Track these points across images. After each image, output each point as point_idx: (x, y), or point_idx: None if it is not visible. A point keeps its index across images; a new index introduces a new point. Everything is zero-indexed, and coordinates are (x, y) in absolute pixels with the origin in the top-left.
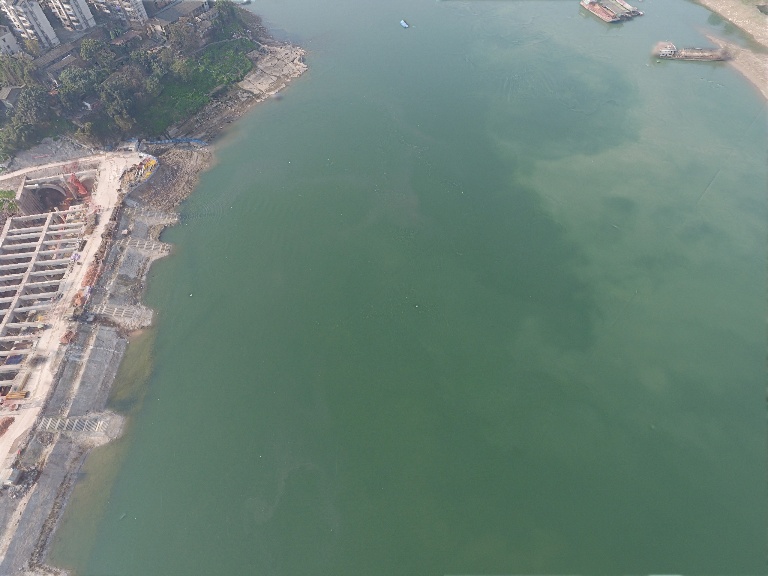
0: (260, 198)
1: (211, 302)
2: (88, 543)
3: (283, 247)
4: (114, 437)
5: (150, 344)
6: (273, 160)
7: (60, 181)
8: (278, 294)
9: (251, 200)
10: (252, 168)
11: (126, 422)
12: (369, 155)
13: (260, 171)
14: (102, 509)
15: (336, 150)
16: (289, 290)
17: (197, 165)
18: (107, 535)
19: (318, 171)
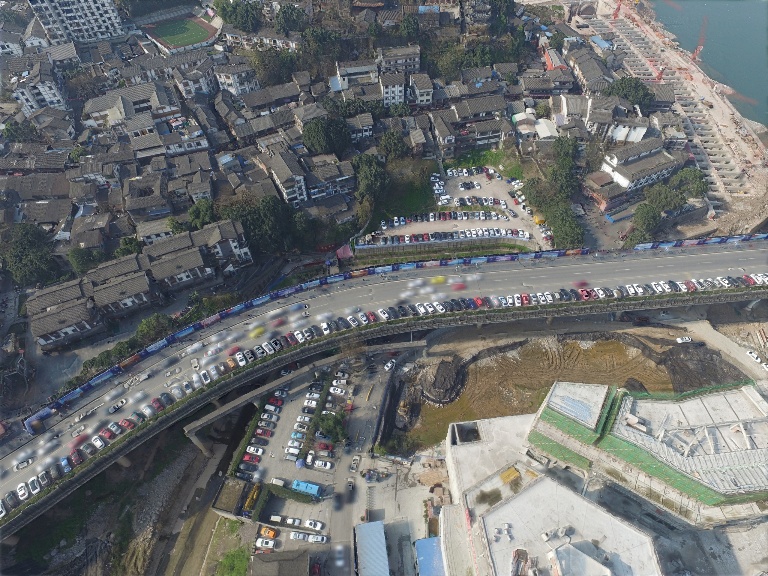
0: (705, 18)
1: (726, 54)
2: (759, 120)
3: (744, 37)
4: (733, 92)
5: (710, 67)
6: (693, 3)
7: (573, 6)
8: (763, 52)
9: (700, 19)
10: (682, 7)
11: (732, 88)
12: (754, 3)
13: (689, 8)
14: (754, 111)
15: (728, 1)
16: (767, 52)
17: (647, 4)
18: (766, 118)
19: (729, 8)
